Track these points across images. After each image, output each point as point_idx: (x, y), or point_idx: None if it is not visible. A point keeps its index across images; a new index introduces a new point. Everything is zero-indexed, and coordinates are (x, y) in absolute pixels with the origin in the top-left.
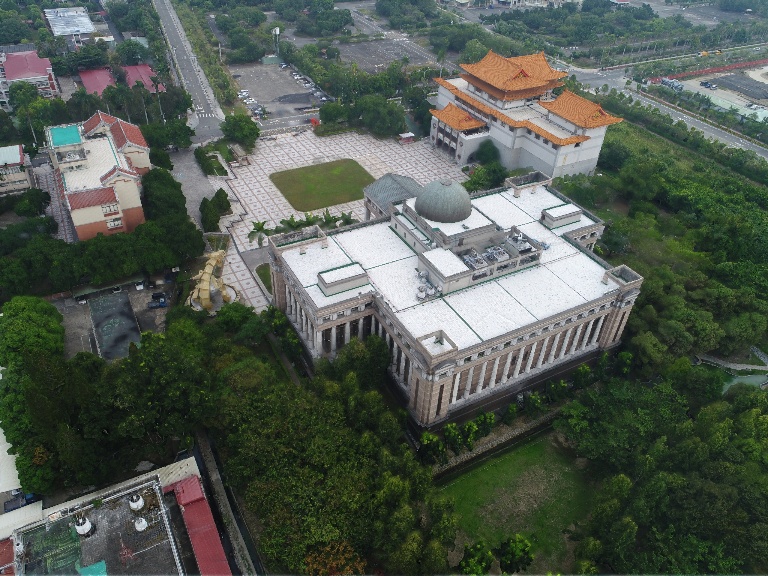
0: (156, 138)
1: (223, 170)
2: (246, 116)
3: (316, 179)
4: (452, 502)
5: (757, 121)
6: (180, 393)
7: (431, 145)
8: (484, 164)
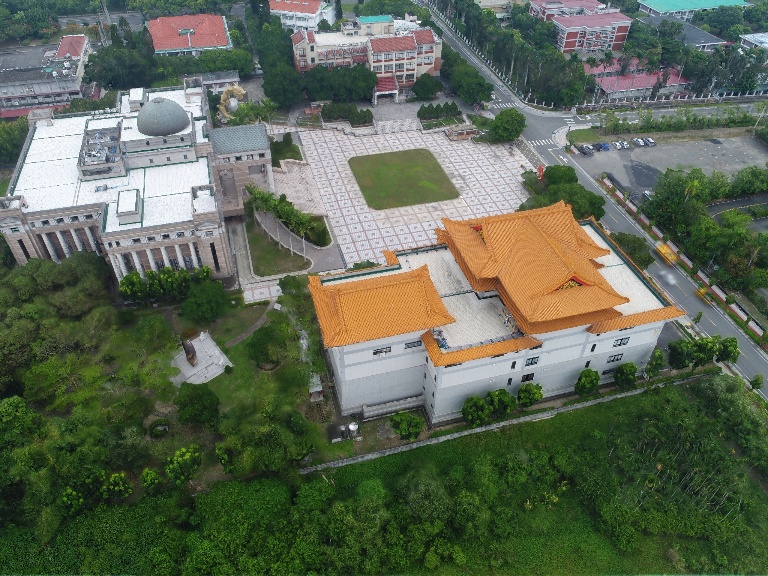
0: (452, 77)
1: (429, 123)
2: (511, 115)
3: (410, 171)
4: None
5: None
6: (95, 62)
7: None
8: None
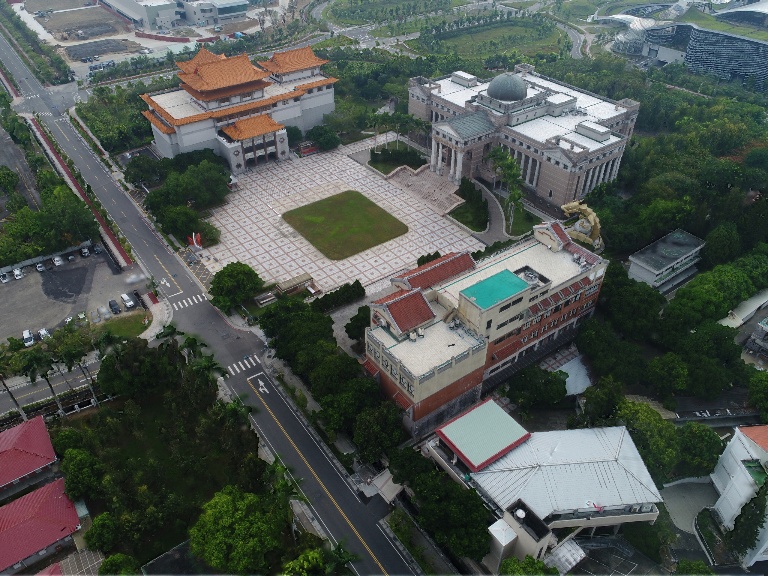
0: None
1: None
2: (230, 265)
3: (339, 229)
4: (686, 126)
5: (191, 51)
6: None
7: (245, 172)
8: (290, 146)
